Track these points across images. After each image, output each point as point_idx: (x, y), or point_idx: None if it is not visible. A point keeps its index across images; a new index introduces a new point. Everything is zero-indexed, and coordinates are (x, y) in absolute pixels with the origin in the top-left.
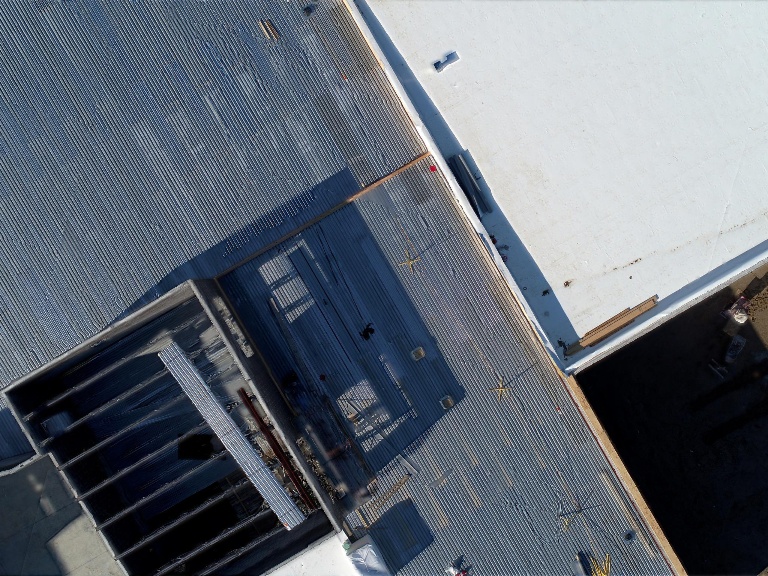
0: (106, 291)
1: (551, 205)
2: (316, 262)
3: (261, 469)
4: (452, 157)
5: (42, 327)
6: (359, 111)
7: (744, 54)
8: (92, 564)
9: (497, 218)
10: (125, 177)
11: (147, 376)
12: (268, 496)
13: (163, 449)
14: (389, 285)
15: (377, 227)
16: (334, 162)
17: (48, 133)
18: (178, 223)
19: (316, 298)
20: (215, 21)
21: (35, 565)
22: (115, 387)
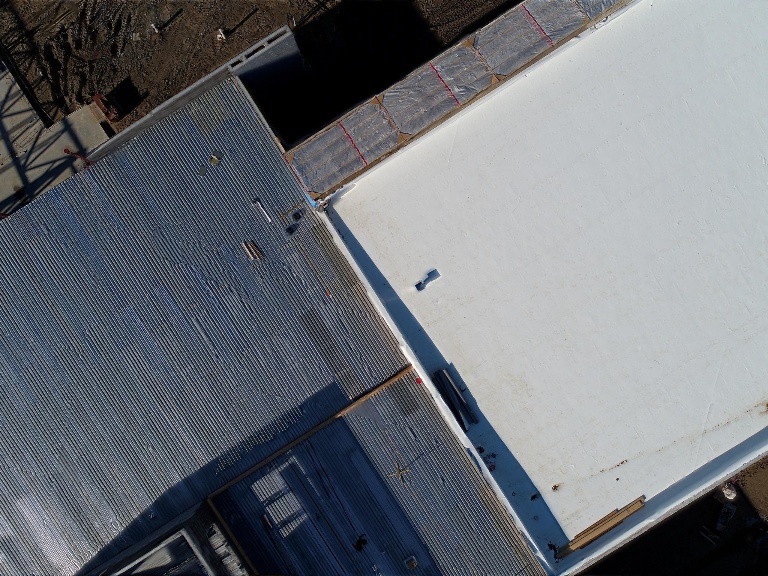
0: (102, 513)
1: (536, 413)
2: (307, 477)
3: None
4: (437, 372)
5: (41, 551)
6: (344, 326)
7: (721, 258)
8: None
9: (483, 428)
10: (117, 401)
11: None
12: None
13: None
14: (380, 496)
15: (366, 440)
16: (321, 377)
17: (40, 362)
18: (170, 443)
19: (308, 512)
20: (199, 239)
21: None
22: None
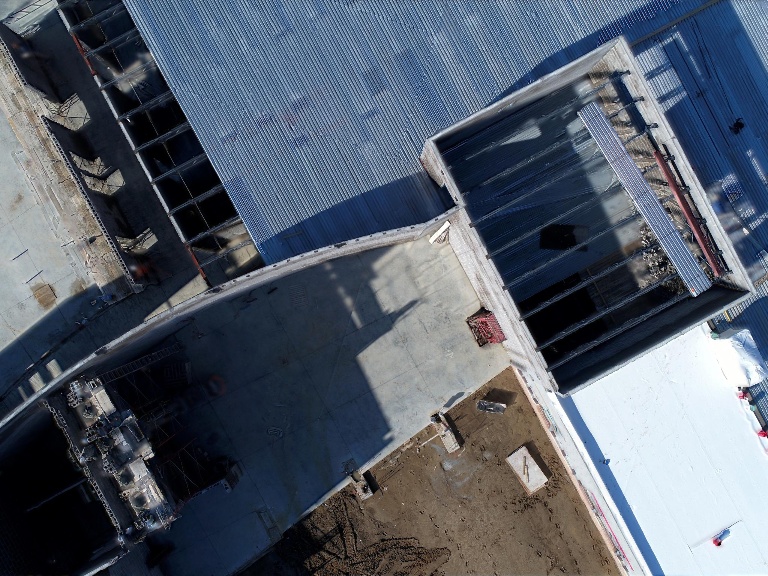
0: (481, 75)
1: None
2: (690, 55)
3: (672, 233)
4: None
5: (417, 108)
6: None
7: None
8: (400, 379)
9: None
10: None
11: (513, 164)
12: (677, 261)
13: (576, 209)
14: (759, 81)
15: (750, 23)
16: None
17: None
18: (554, 12)
19: (688, 90)
20: None
21: (343, 378)
22: (481, 174)
